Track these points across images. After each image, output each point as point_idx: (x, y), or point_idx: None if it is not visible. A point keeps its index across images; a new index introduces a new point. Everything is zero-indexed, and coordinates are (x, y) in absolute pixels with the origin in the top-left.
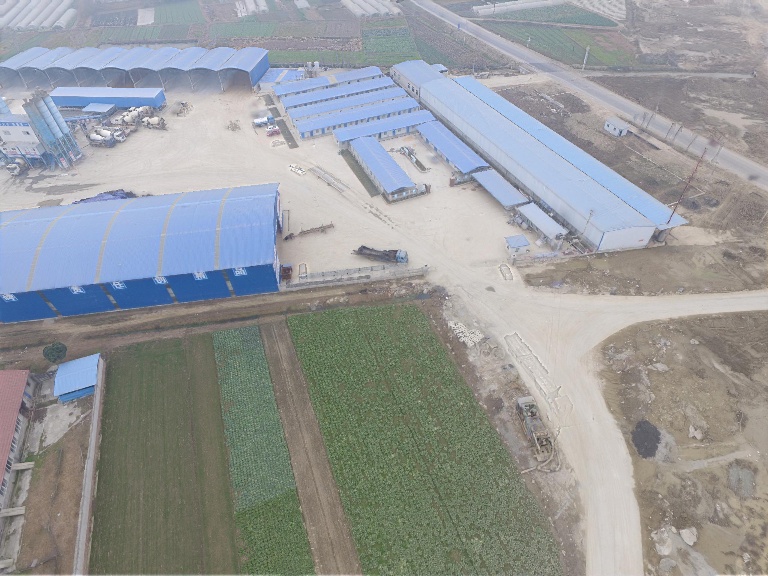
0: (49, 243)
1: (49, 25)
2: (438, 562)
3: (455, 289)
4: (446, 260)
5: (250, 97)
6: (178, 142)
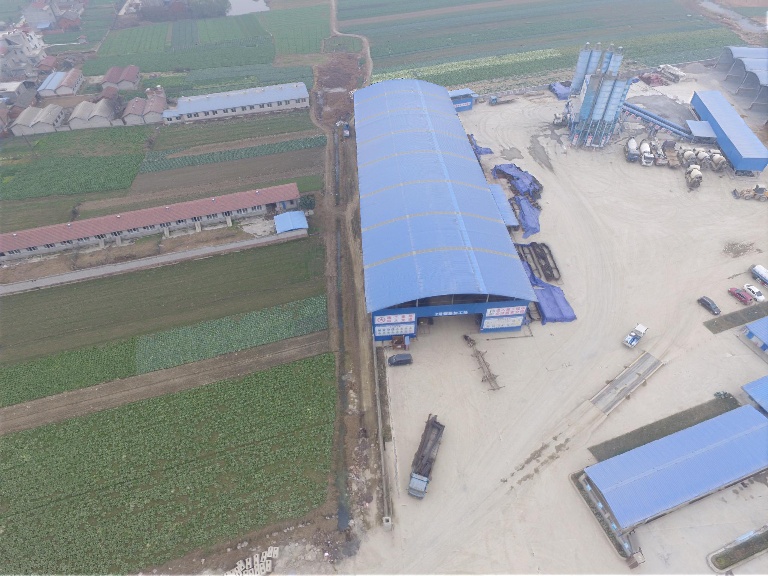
0: (402, 157)
1: None
2: (8, 489)
3: (348, 575)
4: (419, 570)
5: None
6: (664, 206)
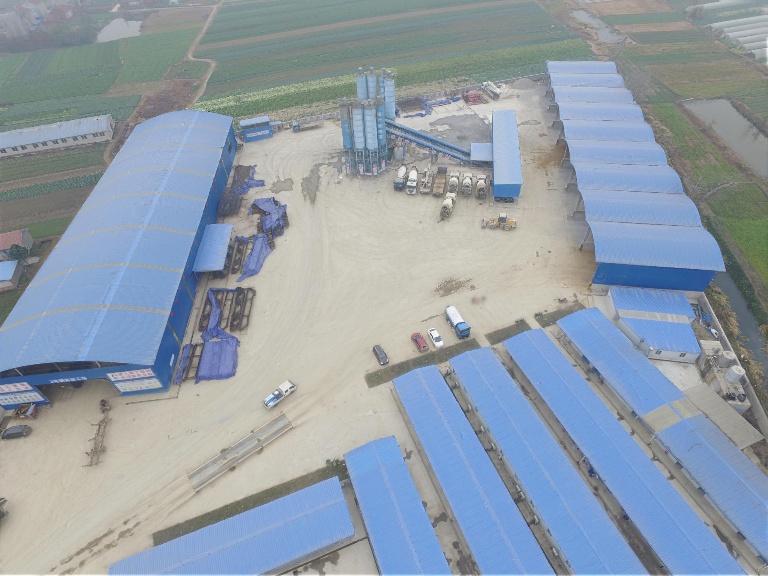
0: (116, 200)
1: (751, 48)
2: None
3: None
4: None
5: (568, 287)
6: (404, 239)
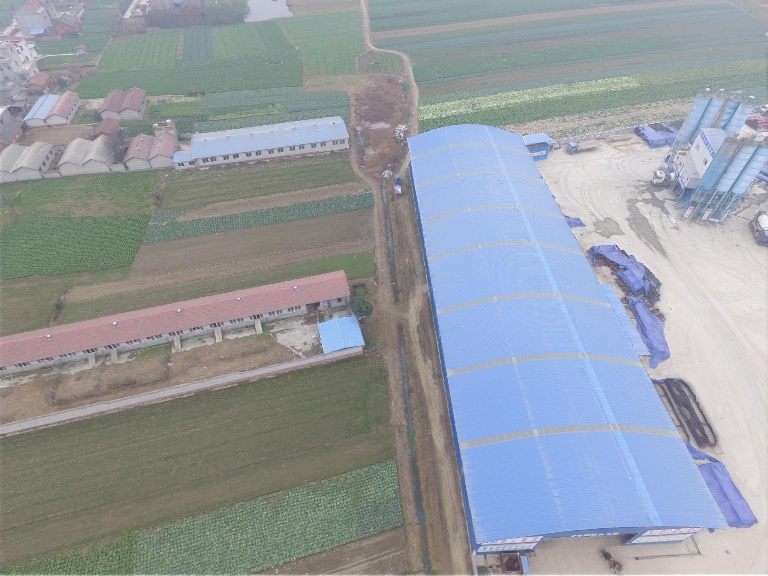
0: (488, 251)
1: None
2: None
3: None
4: None
5: None
6: None
